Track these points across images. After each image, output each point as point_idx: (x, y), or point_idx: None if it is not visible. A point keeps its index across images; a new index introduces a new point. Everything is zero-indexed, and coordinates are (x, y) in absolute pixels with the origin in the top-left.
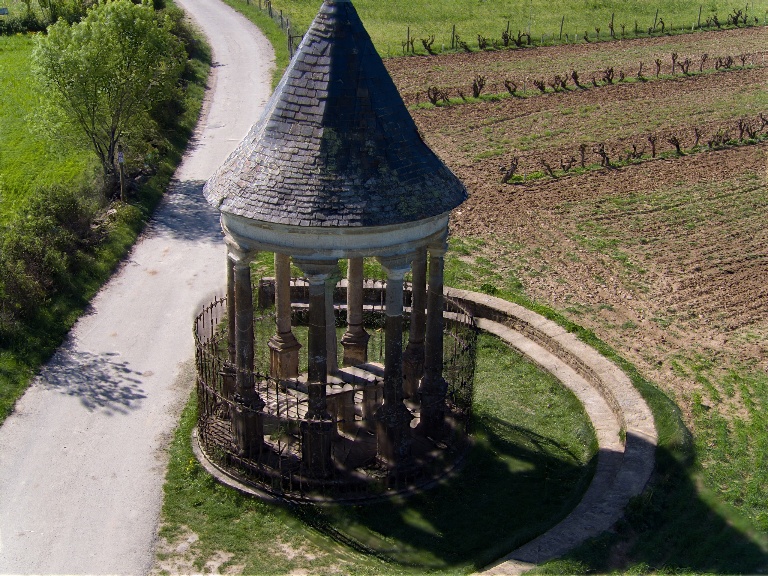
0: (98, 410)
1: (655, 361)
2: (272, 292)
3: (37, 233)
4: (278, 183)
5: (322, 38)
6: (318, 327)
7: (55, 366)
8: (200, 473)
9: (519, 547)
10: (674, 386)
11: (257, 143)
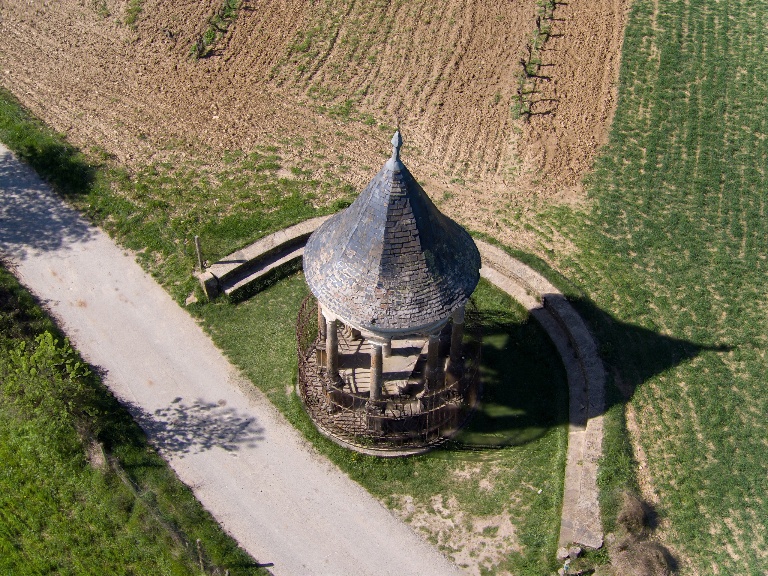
0: (238, 452)
1: (493, 224)
2: (216, 285)
3: (5, 334)
4: (413, 298)
5: (401, 197)
6: (437, 355)
7: (157, 435)
8: (363, 458)
9: (569, 405)
10: (523, 242)
11: (378, 276)
